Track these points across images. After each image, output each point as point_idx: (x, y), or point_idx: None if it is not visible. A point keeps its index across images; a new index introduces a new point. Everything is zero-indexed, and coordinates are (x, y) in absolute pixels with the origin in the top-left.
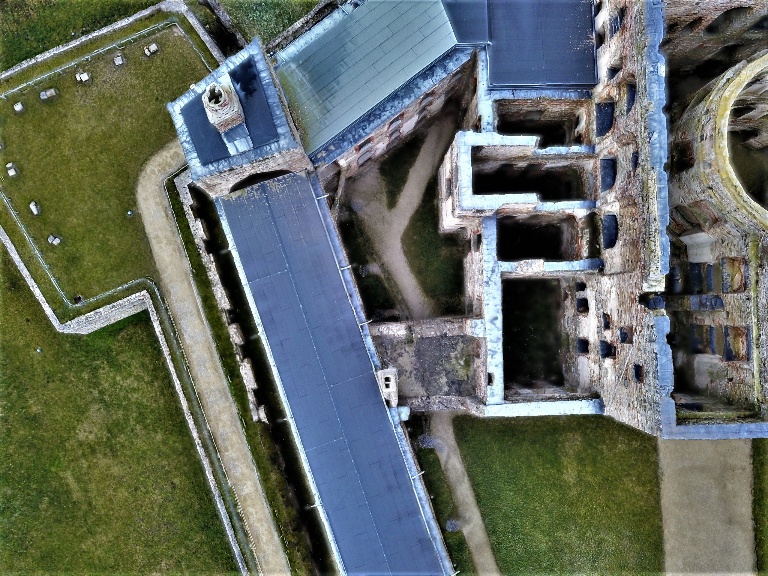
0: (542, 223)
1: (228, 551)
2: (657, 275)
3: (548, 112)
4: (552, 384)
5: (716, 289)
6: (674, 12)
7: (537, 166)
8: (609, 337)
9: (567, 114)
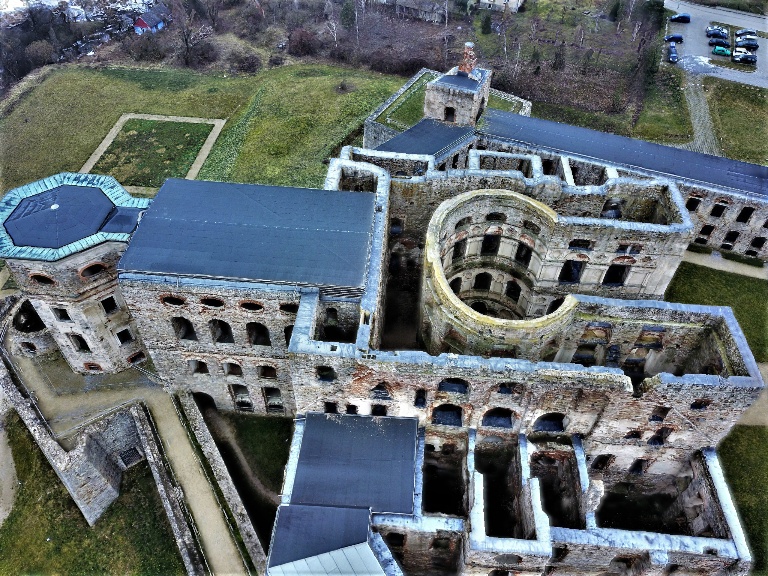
0: None
1: None
2: (624, 378)
3: None
4: (667, 505)
5: None
6: None
7: None
8: (650, 433)
9: None
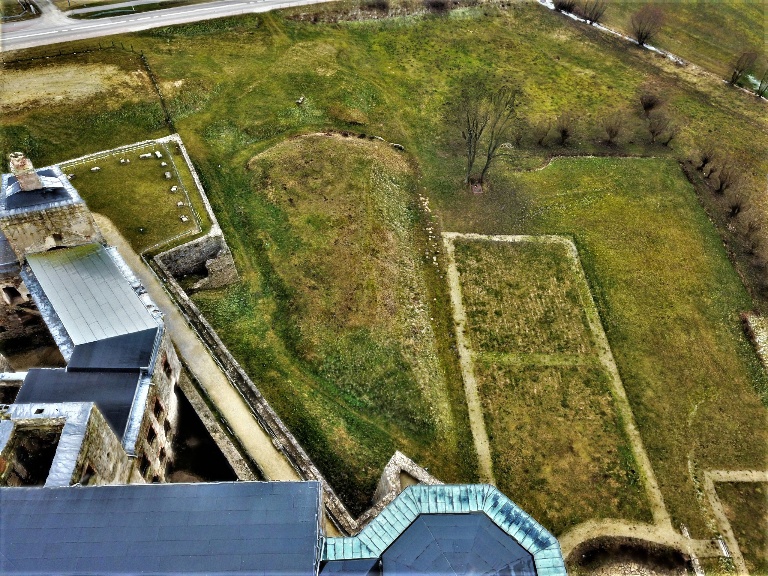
0: None
1: None
2: None
3: None
4: None
5: None
6: None
7: None
8: None
9: None
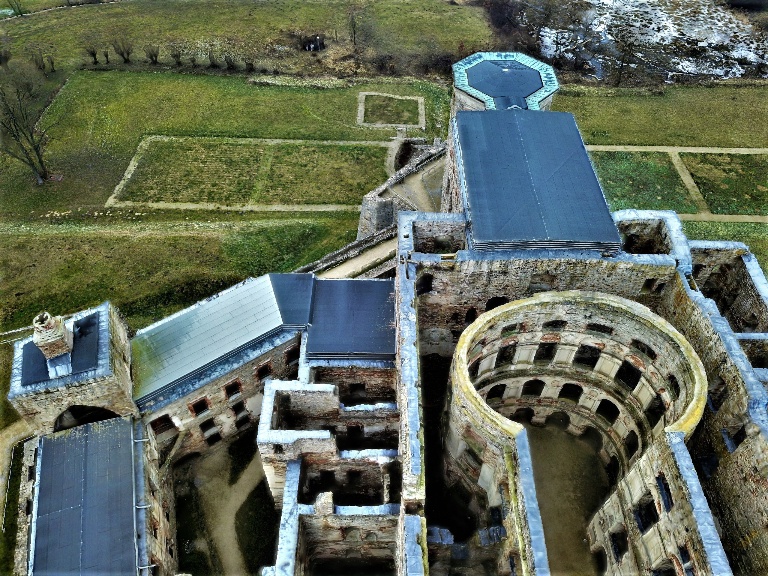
0: (368, 490)
1: None
2: (409, 476)
3: (368, 386)
4: None
5: (566, 575)
6: (448, 301)
7: (358, 430)
8: None
9: (387, 389)
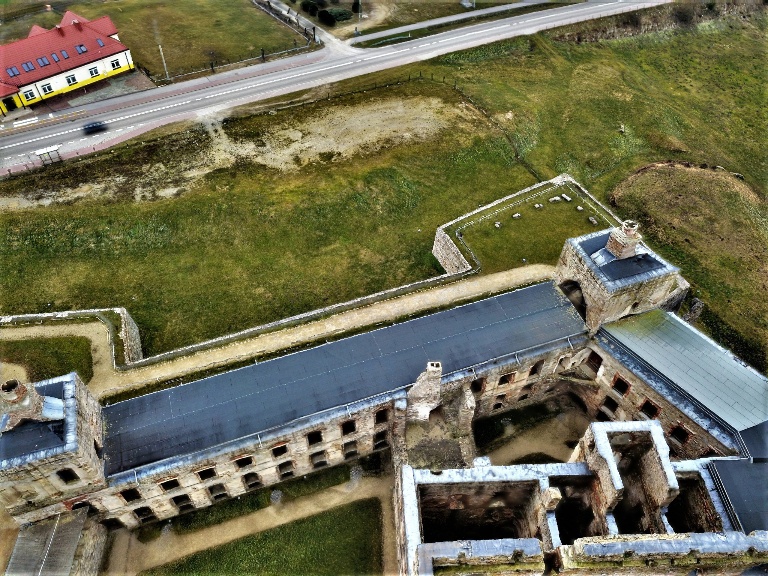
0: None
1: None
2: (581, 544)
3: None
4: None
5: None
6: None
7: None
8: None
9: None
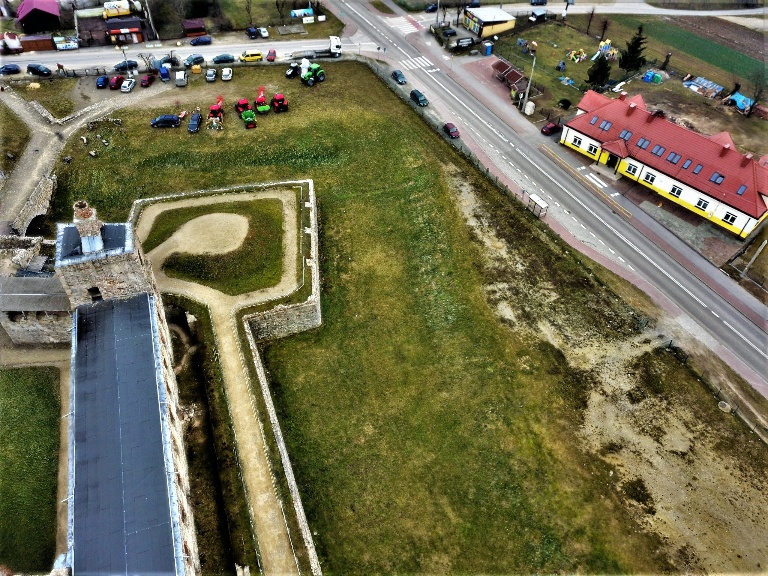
0: None
1: (305, 450)
2: None
3: None
4: None
5: None
6: None
7: None
8: None
9: None
